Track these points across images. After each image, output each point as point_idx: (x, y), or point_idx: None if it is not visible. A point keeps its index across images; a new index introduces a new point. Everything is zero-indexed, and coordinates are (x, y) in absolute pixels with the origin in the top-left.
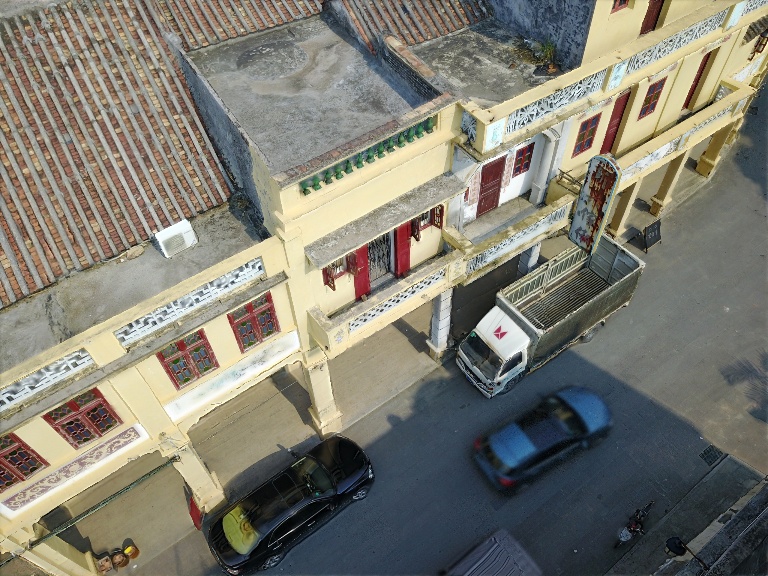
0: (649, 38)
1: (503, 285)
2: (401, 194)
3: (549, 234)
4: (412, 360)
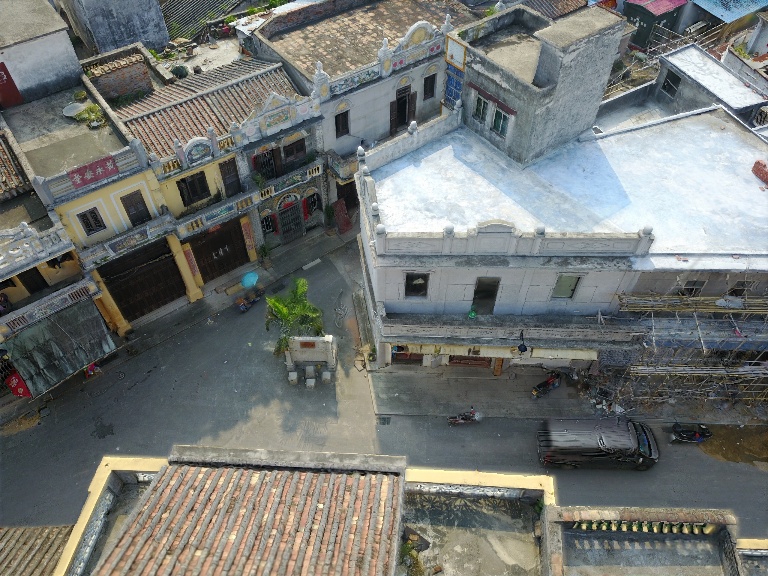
0: None
1: None
2: None
3: None
4: None
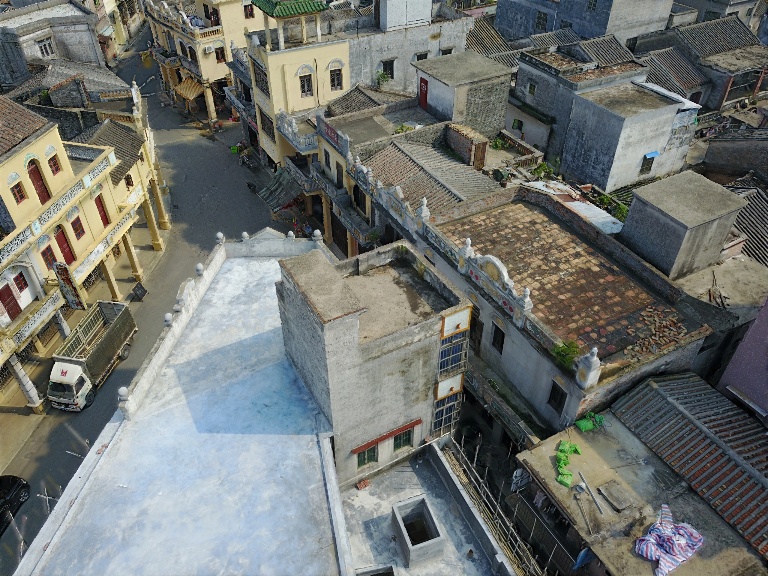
0: (43, 208)
1: None
2: None
3: (57, 310)
4: (25, 422)
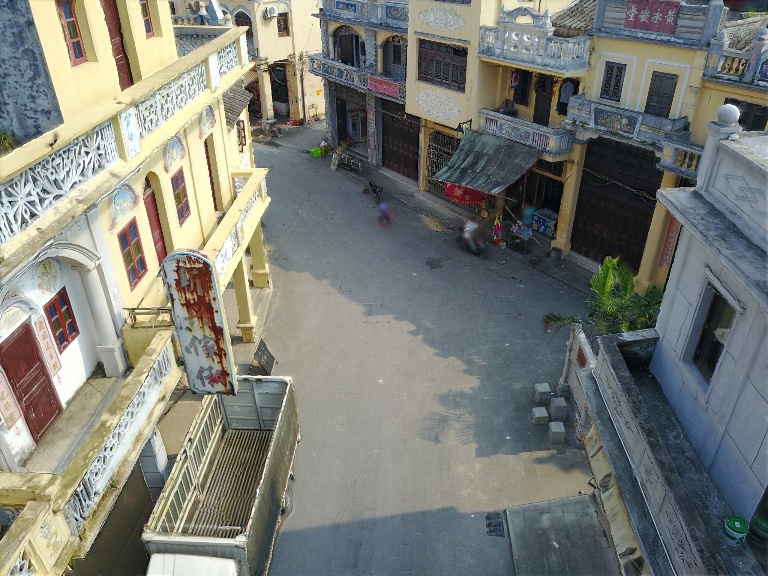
0: (142, 84)
1: (138, 525)
2: None
3: (166, 399)
4: None
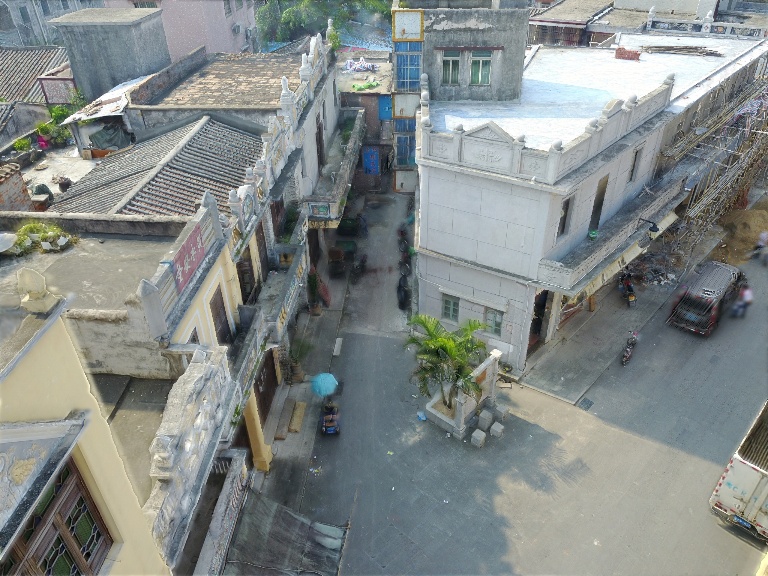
0: None
1: None
2: None
3: None
4: None
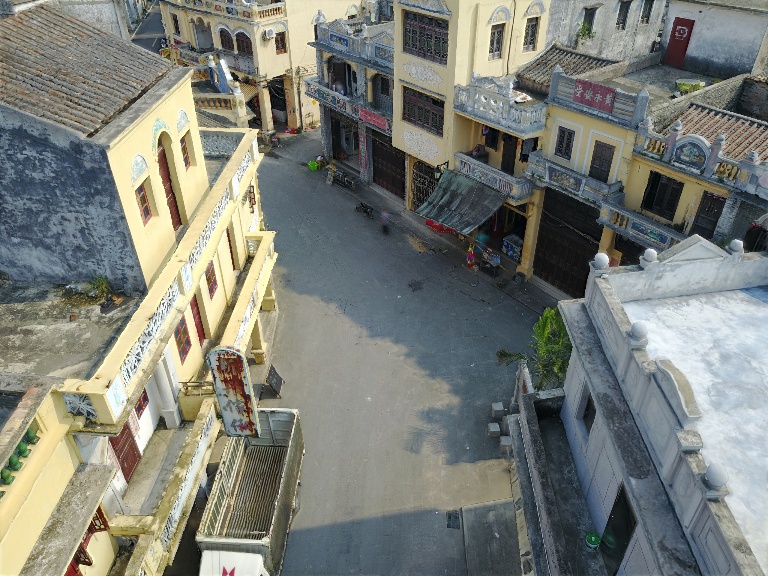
0: (191, 233)
1: None
2: (40, 532)
3: (212, 446)
4: None
